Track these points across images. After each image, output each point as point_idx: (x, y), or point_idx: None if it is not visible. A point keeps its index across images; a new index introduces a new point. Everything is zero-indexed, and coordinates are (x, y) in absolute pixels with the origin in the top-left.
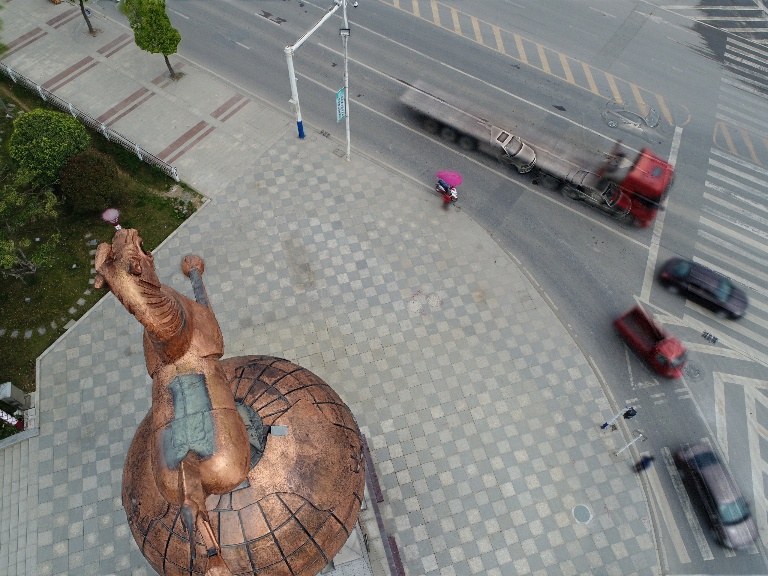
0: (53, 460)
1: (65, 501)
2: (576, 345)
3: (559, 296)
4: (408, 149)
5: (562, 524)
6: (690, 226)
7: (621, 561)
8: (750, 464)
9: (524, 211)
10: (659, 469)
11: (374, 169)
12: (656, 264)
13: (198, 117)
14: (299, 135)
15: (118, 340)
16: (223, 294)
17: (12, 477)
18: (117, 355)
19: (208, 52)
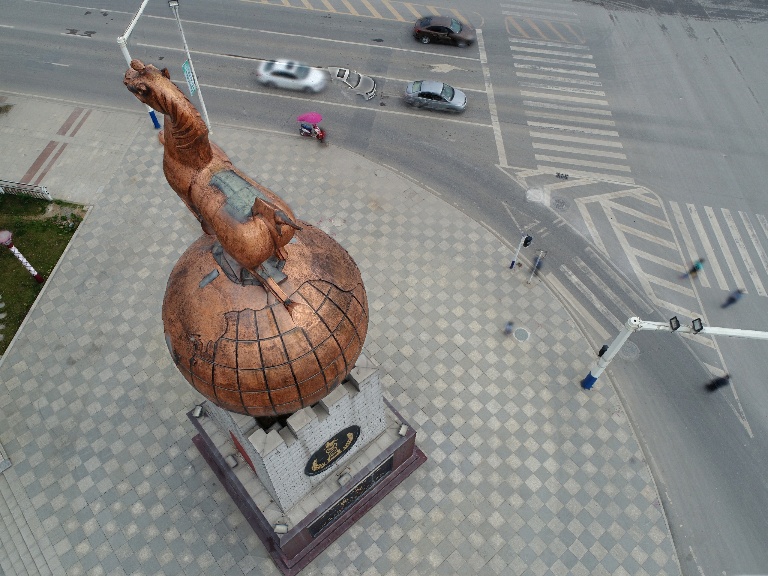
0: (38, 480)
1: (68, 508)
2: (466, 216)
3: (438, 184)
4: (262, 109)
5: (510, 348)
6: (516, 100)
7: (563, 356)
8: (625, 254)
9: (383, 129)
10: (564, 282)
11: (238, 134)
12: (502, 136)
13: (45, 139)
14: (155, 126)
15: (55, 355)
16: (143, 281)
17: (0, 513)
18: (61, 368)
19: (27, 80)
